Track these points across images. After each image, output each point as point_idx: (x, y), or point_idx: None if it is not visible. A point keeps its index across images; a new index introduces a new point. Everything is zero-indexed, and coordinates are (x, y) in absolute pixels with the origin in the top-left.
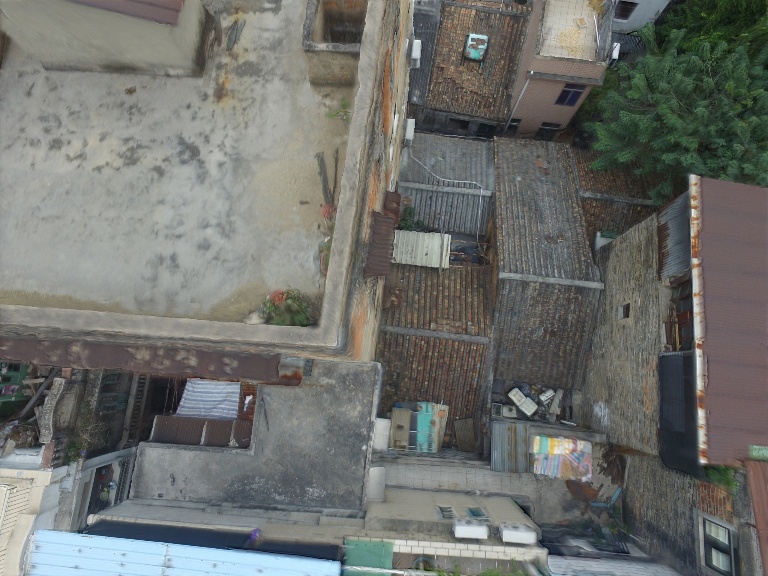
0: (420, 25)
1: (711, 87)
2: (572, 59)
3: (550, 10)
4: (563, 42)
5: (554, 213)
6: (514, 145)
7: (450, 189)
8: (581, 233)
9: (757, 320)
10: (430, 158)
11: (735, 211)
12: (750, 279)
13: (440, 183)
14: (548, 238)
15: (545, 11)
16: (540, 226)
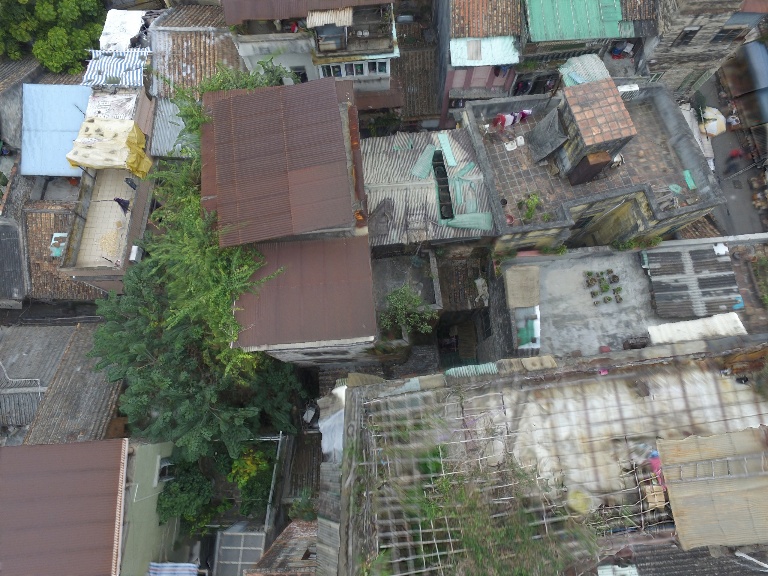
0: (2, 235)
1: (132, 310)
2: (91, 268)
3: (94, 216)
4: (103, 244)
5: (89, 405)
6: (91, 331)
7: (12, 390)
8: (102, 424)
9: (22, 571)
10: (14, 355)
11: (20, 472)
12: (22, 534)
13: (7, 384)
14: (69, 436)
15: (90, 218)
16: (69, 423)
